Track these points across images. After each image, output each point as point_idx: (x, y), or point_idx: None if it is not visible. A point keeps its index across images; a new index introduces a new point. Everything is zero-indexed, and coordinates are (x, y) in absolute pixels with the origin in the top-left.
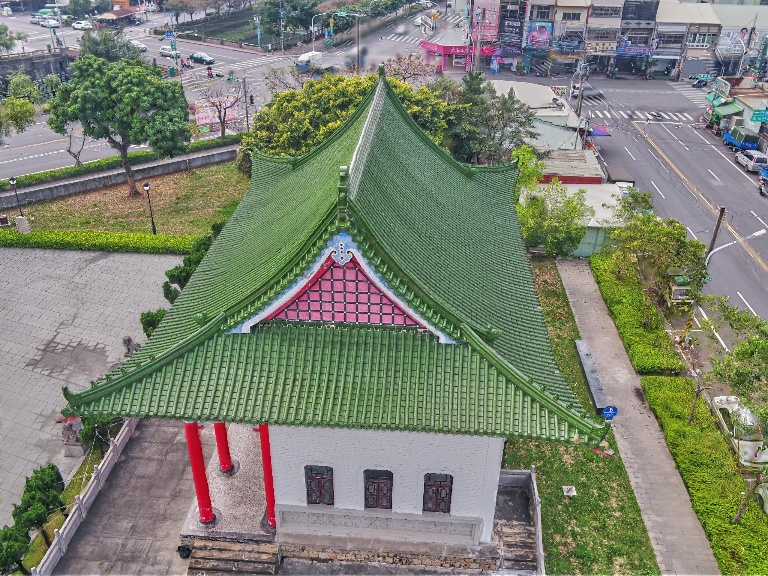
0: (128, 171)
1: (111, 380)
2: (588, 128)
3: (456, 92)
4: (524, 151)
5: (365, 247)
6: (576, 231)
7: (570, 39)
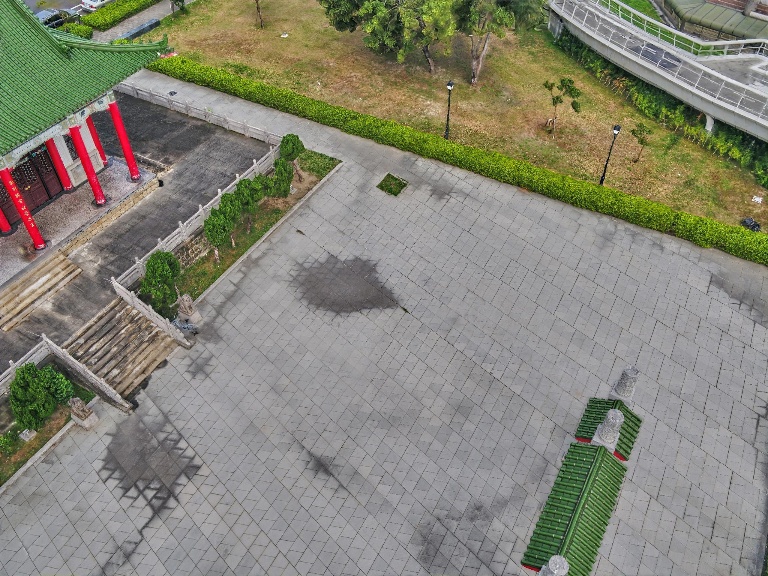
0: None
1: None
2: None
3: None
4: None
5: None
6: None
7: None
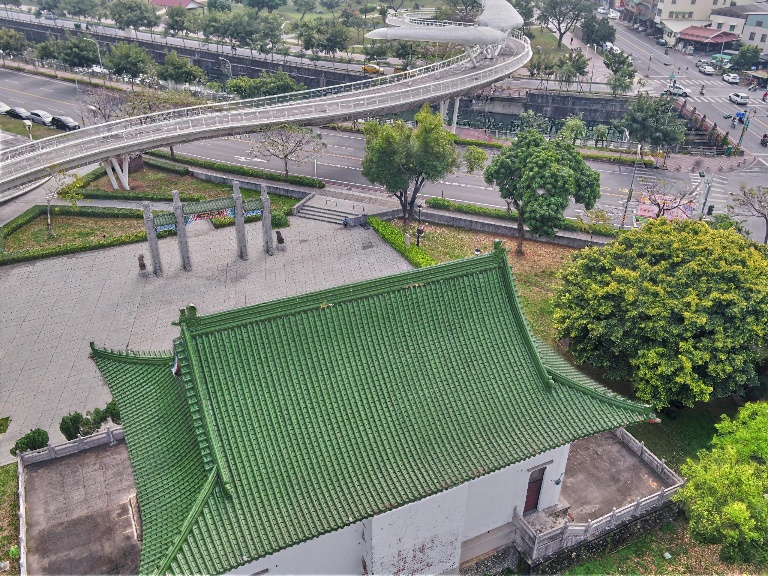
0: (519, 232)
1: (113, 353)
2: None
3: None
4: (762, 410)
5: (181, 364)
6: (760, 546)
7: None
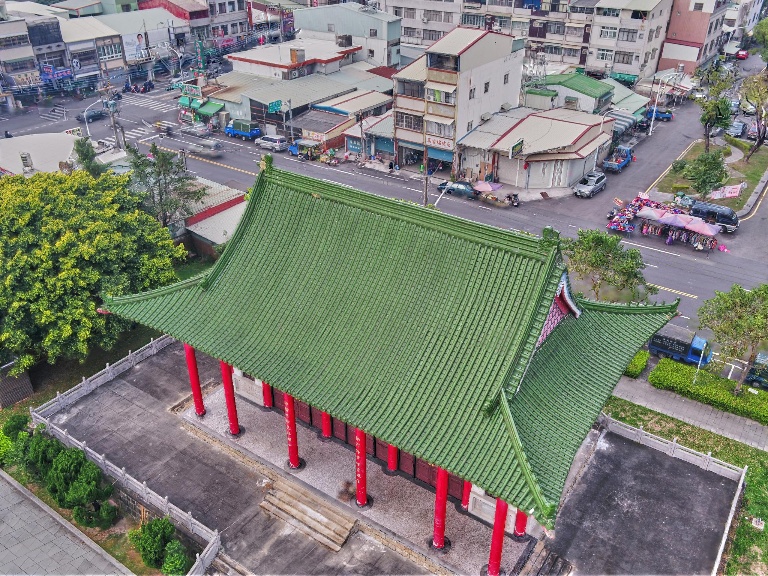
0: None
1: None
2: (185, 158)
3: (63, 166)
4: None
5: None
6: None
7: (40, 79)
